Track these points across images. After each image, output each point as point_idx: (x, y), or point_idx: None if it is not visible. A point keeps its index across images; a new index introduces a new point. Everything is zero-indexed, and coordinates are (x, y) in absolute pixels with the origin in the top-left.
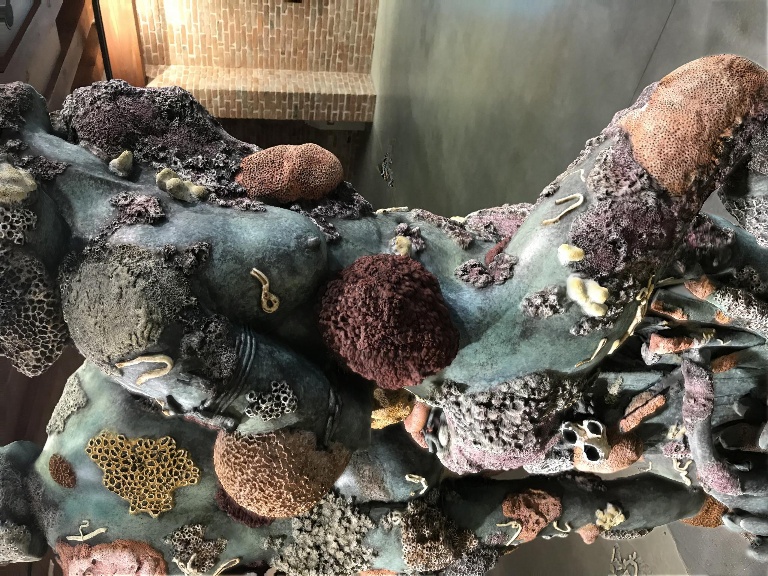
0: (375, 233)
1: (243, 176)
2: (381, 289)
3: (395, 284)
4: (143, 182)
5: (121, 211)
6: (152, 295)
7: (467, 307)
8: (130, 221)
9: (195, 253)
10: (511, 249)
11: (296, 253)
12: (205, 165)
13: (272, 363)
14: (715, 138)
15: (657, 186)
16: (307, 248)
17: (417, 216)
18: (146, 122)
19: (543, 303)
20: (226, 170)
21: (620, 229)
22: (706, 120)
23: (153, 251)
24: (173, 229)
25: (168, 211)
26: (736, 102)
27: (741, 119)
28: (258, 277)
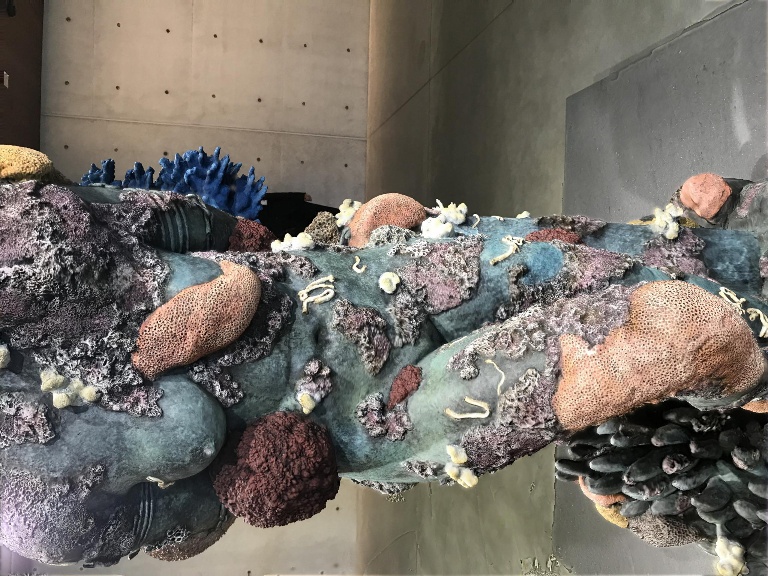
0: (283, 374)
1: (140, 356)
2: (267, 499)
3: (282, 491)
4: (27, 377)
5: (8, 419)
6: (50, 542)
7: (355, 452)
8: (19, 441)
9: (89, 486)
10: (413, 408)
11: (190, 465)
12: (95, 352)
13: (168, 517)
14: (639, 403)
15: (560, 428)
16: (202, 458)
17: (337, 327)
18: (19, 317)
19: (420, 472)
20: (120, 350)
21: (509, 450)
22: (638, 396)
23: (47, 478)
24: (65, 449)
25: (58, 423)
26: (679, 384)
27: (676, 392)
28: (153, 481)
